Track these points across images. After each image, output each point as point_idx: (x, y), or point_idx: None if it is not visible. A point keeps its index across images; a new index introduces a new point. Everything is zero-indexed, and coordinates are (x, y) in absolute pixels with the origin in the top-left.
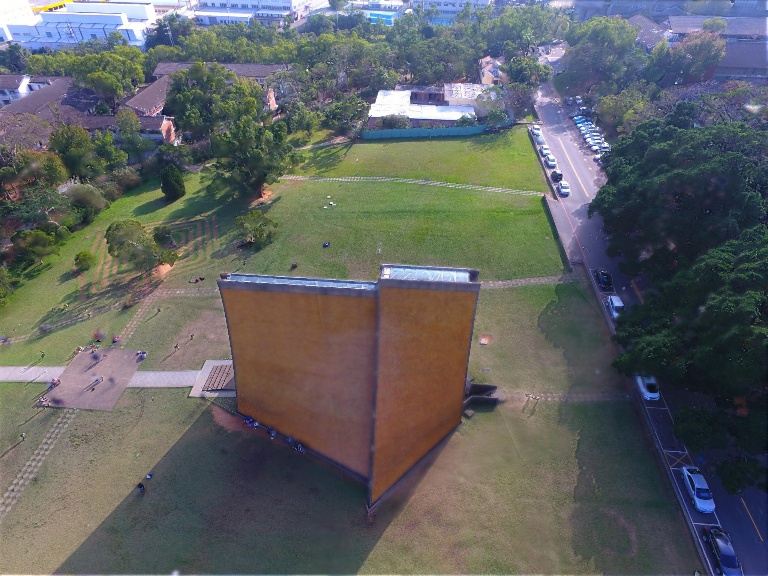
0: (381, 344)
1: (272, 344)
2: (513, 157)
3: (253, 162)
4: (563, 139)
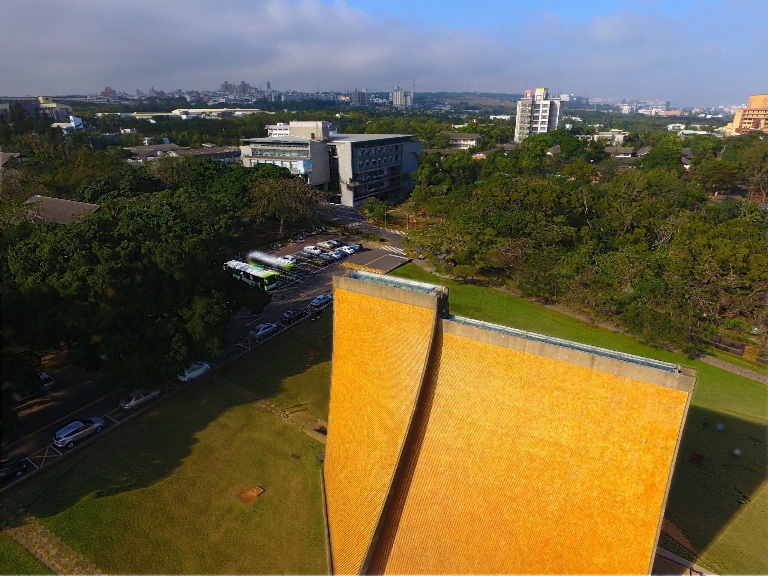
0: None
1: None
2: None
3: None
4: None
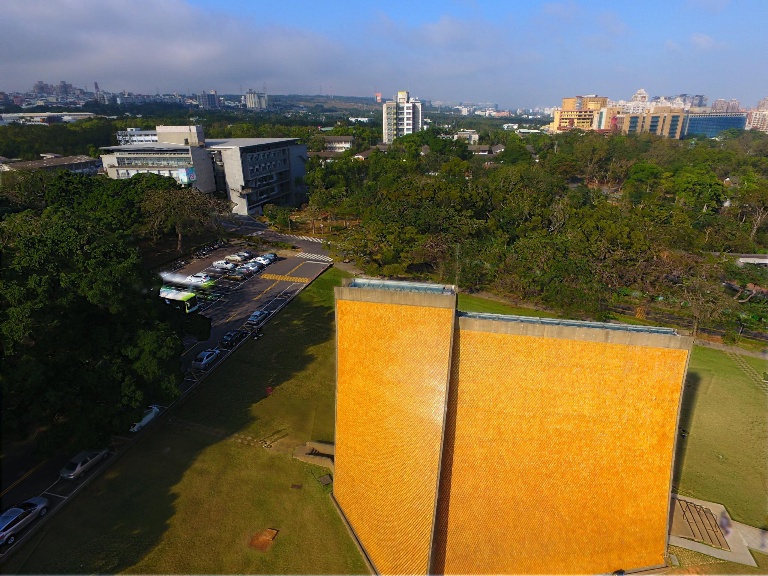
0: None
1: None
2: None
3: None
4: None
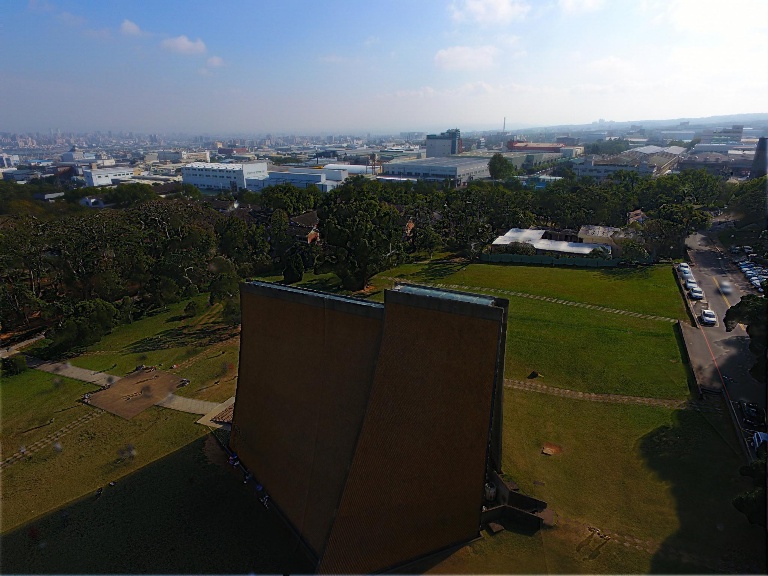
0: (377, 376)
1: (274, 365)
2: (647, 287)
3: (358, 250)
4: (719, 279)
